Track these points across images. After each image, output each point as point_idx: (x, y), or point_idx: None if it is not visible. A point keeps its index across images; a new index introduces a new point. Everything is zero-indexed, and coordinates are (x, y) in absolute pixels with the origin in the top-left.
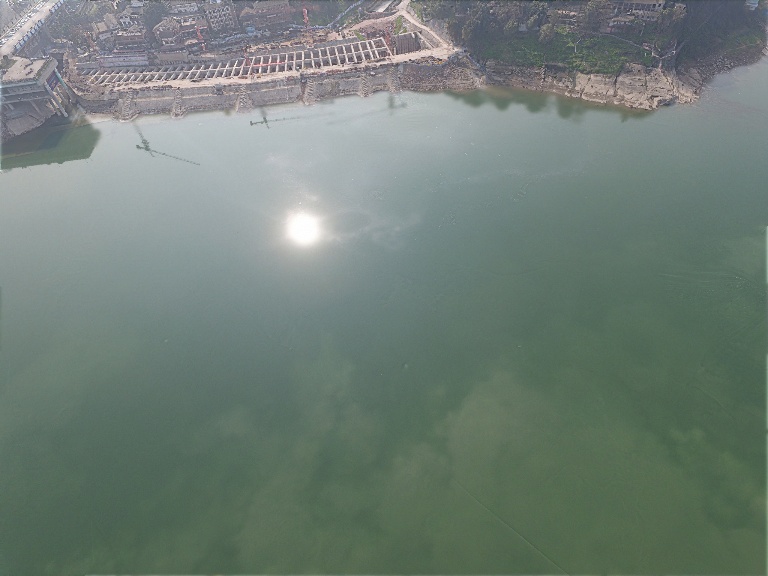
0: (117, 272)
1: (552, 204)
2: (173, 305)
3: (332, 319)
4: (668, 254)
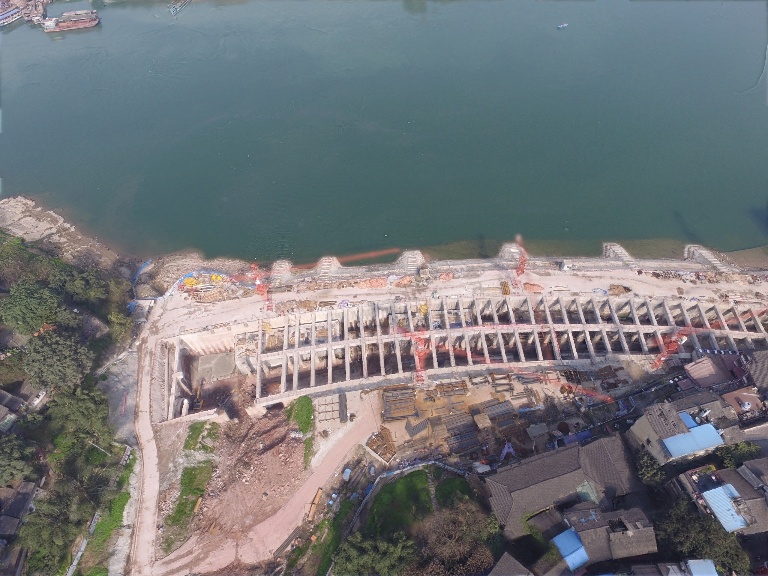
0: (537, 92)
1: (213, 111)
2: (485, 79)
3: (382, 61)
4: None
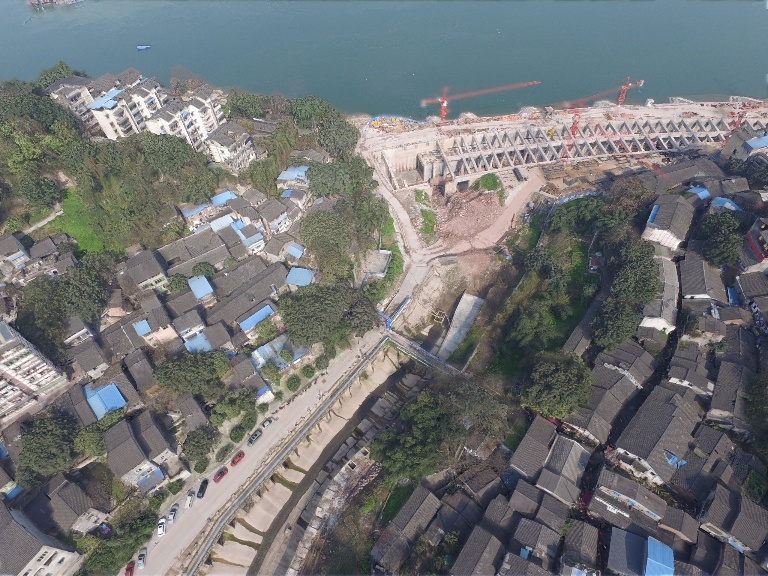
0: (596, 11)
1: (337, 31)
2: None
3: None
4: None
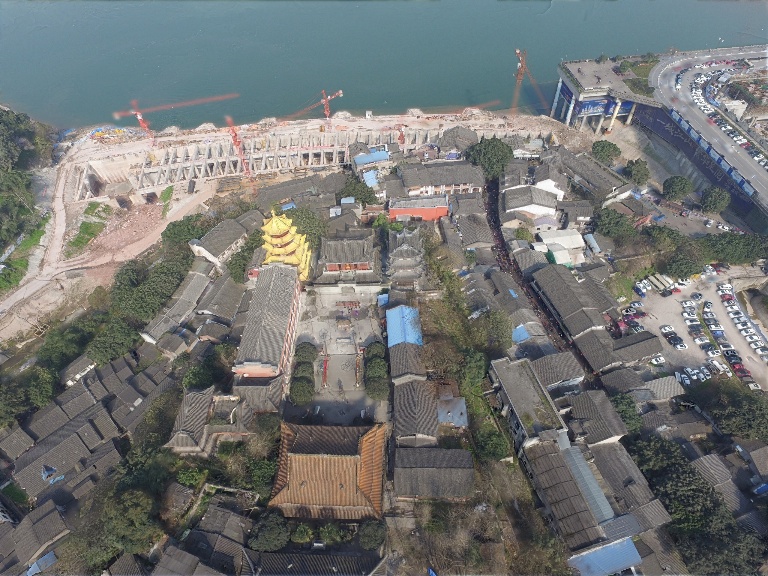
0: (396, 21)
1: (135, 39)
2: None
3: (277, 2)
4: None
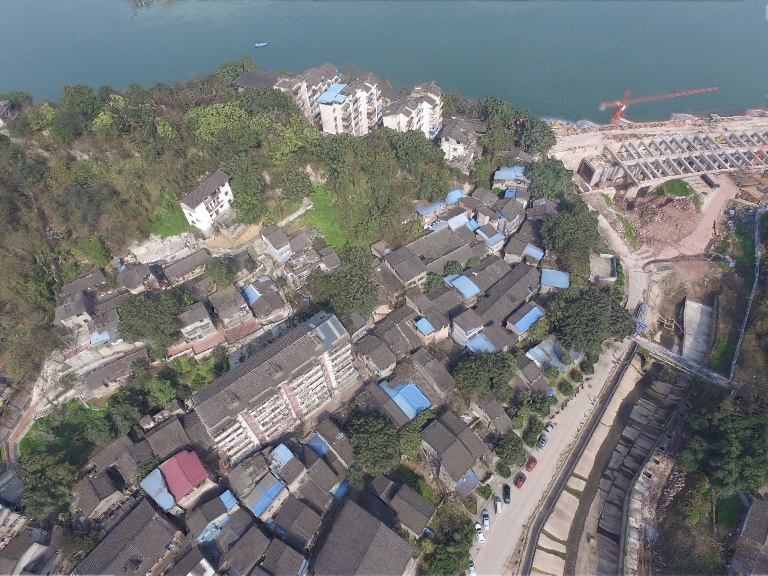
0: (714, 20)
1: (455, 33)
2: (663, 12)
3: None
4: (406, 15)
